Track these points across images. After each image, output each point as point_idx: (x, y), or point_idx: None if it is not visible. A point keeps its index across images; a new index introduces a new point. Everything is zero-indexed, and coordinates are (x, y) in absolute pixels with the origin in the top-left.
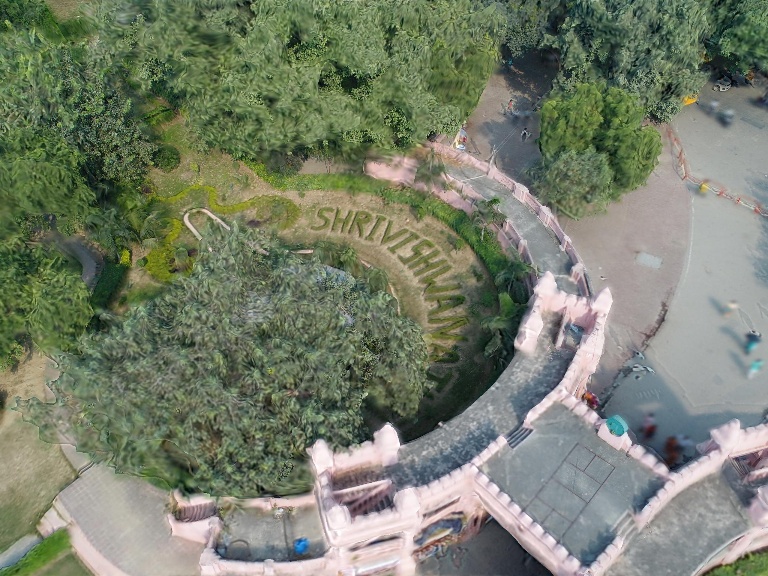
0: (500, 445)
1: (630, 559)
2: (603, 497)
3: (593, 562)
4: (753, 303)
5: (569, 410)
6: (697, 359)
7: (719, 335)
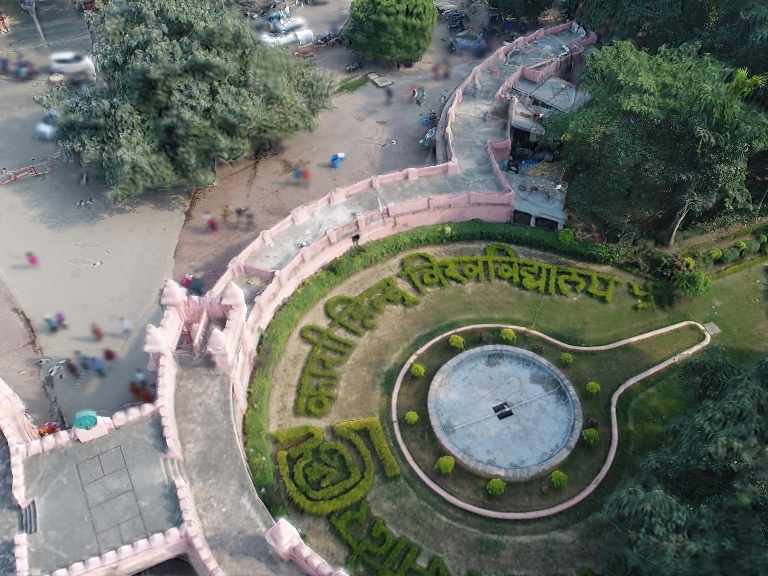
0: (24, 543)
1: (199, 482)
2: (137, 473)
3: (182, 515)
4: (72, 247)
5: (41, 454)
6: (83, 320)
7: (77, 290)
